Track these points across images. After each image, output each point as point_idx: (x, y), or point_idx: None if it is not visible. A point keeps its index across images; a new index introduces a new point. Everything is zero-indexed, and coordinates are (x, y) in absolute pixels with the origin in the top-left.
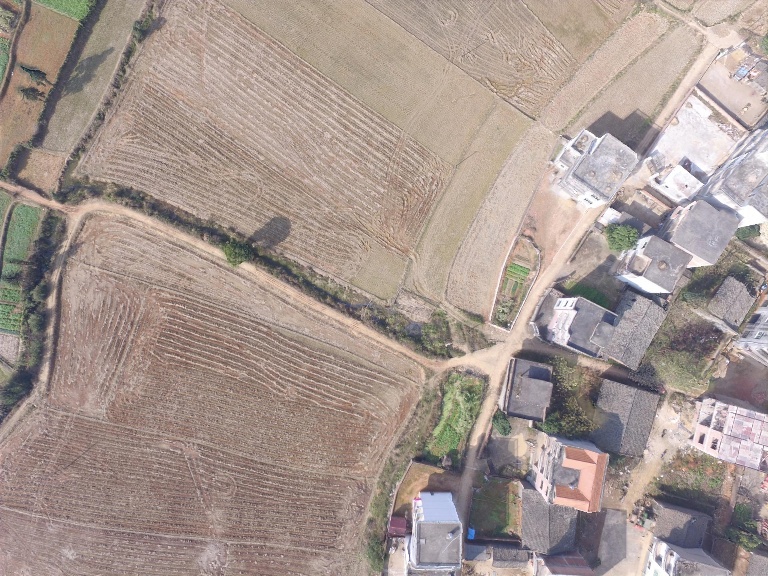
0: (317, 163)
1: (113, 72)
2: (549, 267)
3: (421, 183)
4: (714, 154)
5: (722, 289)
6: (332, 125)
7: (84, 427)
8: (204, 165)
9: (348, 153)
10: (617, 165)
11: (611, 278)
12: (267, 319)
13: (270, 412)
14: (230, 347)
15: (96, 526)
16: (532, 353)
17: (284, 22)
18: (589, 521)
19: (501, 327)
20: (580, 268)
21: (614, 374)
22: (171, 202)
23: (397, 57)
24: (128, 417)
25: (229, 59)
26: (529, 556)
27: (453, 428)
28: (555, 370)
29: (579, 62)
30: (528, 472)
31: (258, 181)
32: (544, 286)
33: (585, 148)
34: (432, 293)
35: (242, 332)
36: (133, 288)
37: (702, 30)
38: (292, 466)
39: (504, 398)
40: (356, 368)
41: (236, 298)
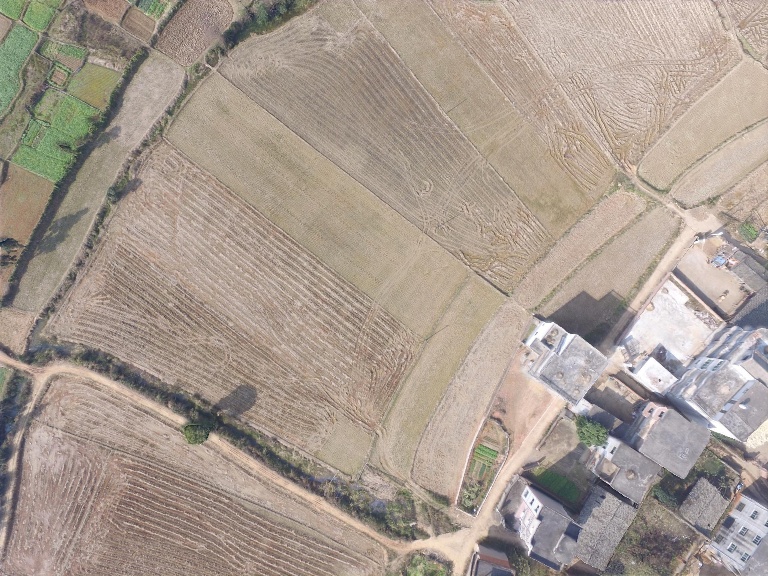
0: (286, 331)
1: (86, 233)
2: (518, 451)
3: (390, 355)
4: (690, 342)
5: (695, 491)
6: (303, 293)
7: None
8: (172, 329)
9: (318, 322)
10: (586, 367)
11: (581, 467)
12: (229, 490)
13: None
14: (190, 518)
15: None
16: (498, 541)
17: (259, 187)
18: None
19: (467, 512)
20: (550, 454)
21: (582, 569)
22: (138, 366)
23: (371, 226)
24: None
25: (202, 222)
26: None
27: None
28: (518, 575)
29: (554, 238)
30: None
31: (226, 347)
32: (512, 471)
33: (555, 342)
34: (398, 471)
35: (203, 503)
36: (95, 452)
37: (680, 212)
38: None
39: None
40: (317, 545)
41: (198, 467)
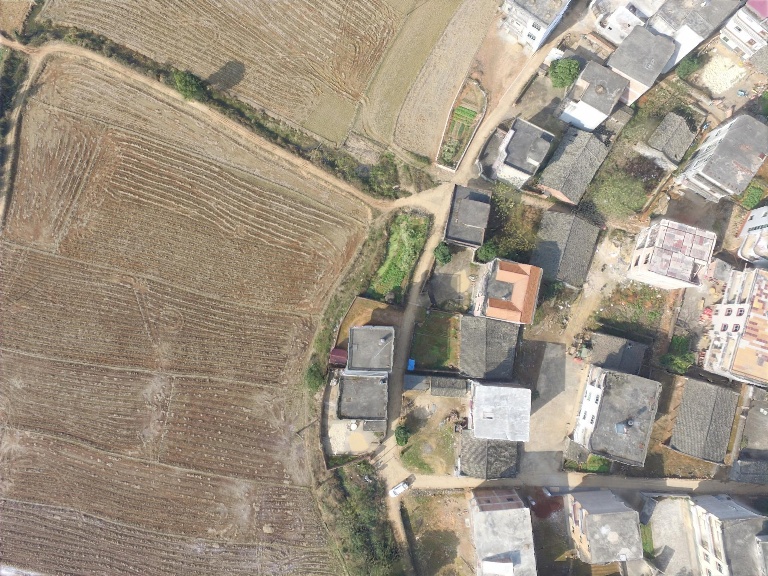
0: (272, 11)
1: None
2: (495, 110)
3: (373, 31)
4: (659, 1)
5: (662, 124)
6: None
7: (37, 260)
8: (163, 11)
9: (303, 1)
10: None
11: (556, 120)
12: (219, 159)
13: (219, 249)
14: (182, 186)
15: (45, 356)
16: None
17: None
18: (528, 352)
19: (447, 167)
20: (525, 110)
21: None
22: (130, 46)
23: None
24: (80, 251)
25: None
26: (468, 386)
27: (398, 267)
28: (494, 194)
29: None
30: (470, 307)
31: (215, 27)
32: (490, 128)
33: None
34: (381, 136)
35: (194, 171)
36: (90, 128)
37: None
38: (239, 302)
39: (445, 228)
40: (304, 208)
41: (190, 139)
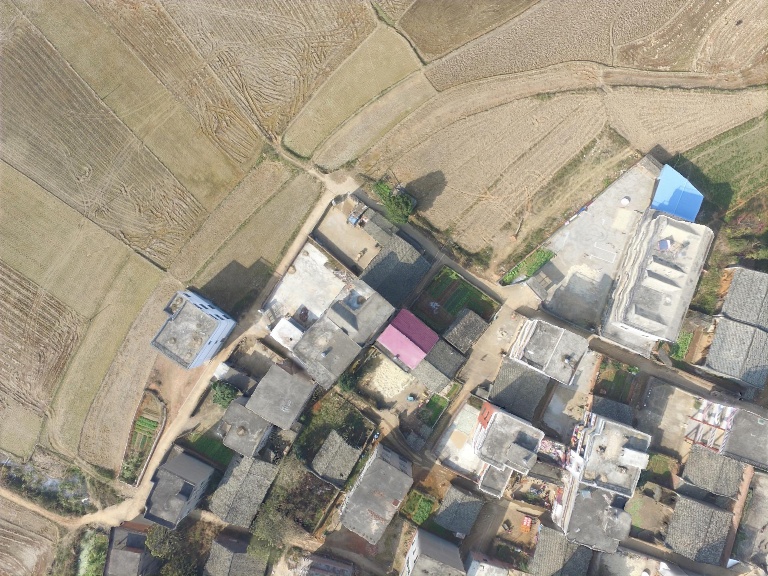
0: None
1: None
2: (175, 420)
3: (57, 338)
4: (330, 301)
5: (325, 443)
6: None
7: None
8: None
9: None
10: (197, 331)
11: None
12: None
13: None
14: None
15: None
16: None
17: None
18: None
19: (128, 483)
20: (204, 420)
21: (236, 529)
22: None
23: (34, 214)
24: None
25: None
26: None
27: None
28: None
29: (209, 211)
30: None
31: None
32: (170, 439)
33: None
34: (67, 449)
35: None
36: None
37: (320, 177)
38: None
39: None
40: None
41: None
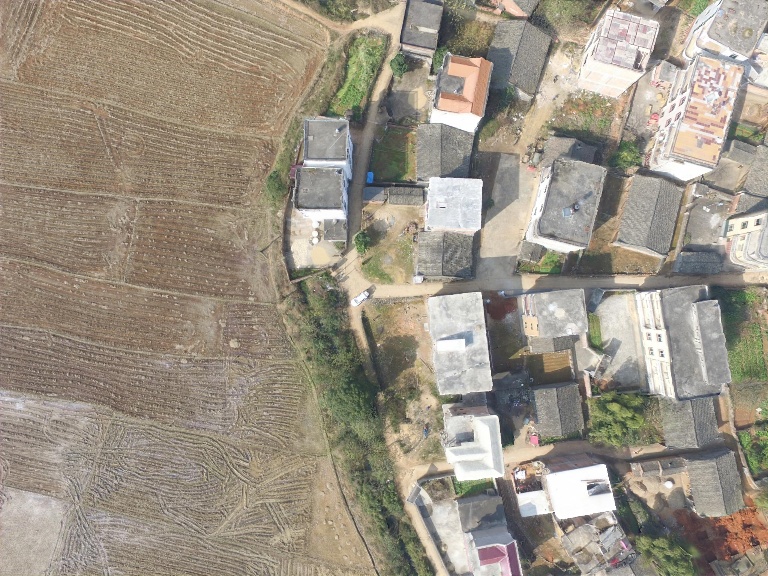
0: None
1: None
2: None
3: None
4: None
5: None
6: None
7: None
8: None
9: None
10: None
11: None
12: None
13: (179, 74)
14: (140, 11)
15: (7, 182)
16: None
17: None
18: None
19: None
20: None
21: None
22: None
23: None
24: (39, 77)
25: None
26: (425, 195)
27: (357, 88)
28: None
29: None
30: (427, 122)
31: None
32: None
33: None
34: None
35: None
36: None
37: None
38: (200, 126)
39: None
40: (263, 32)
41: None
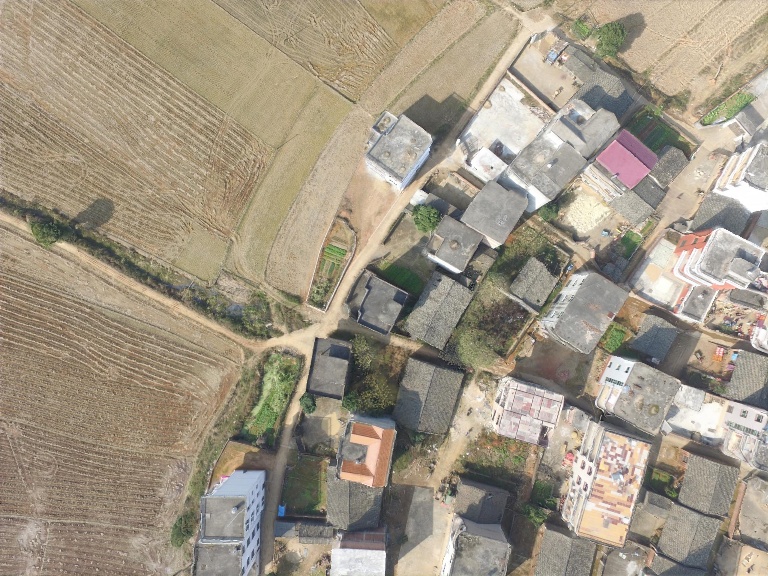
0: (141, 145)
1: None
2: (365, 248)
3: (243, 165)
4: (525, 137)
5: (524, 269)
6: (156, 108)
7: None
8: (29, 147)
9: (172, 136)
10: (412, 146)
11: (424, 259)
12: (90, 300)
13: (92, 392)
14: (53, 328)
15: None
16: (347, 333)
17: (109, 6)
18: (395, 498)
19: (316, 307)
20: (395, 249)
21: (425, 354)
22: None
23: (221, 41)
24: None
25: (55, 42)
26: (336, 533)
27: (271, 407)
28: (353, 348)
29: (400, 46)
30: None
31: (82, 163)
32: (359, 267)
33: None
34: (252, 274)
35: (65, 313)
36: None
37: (517, 15)
38: (113, 445)
39: None
40: (177, 348)
41: (59, 279)
